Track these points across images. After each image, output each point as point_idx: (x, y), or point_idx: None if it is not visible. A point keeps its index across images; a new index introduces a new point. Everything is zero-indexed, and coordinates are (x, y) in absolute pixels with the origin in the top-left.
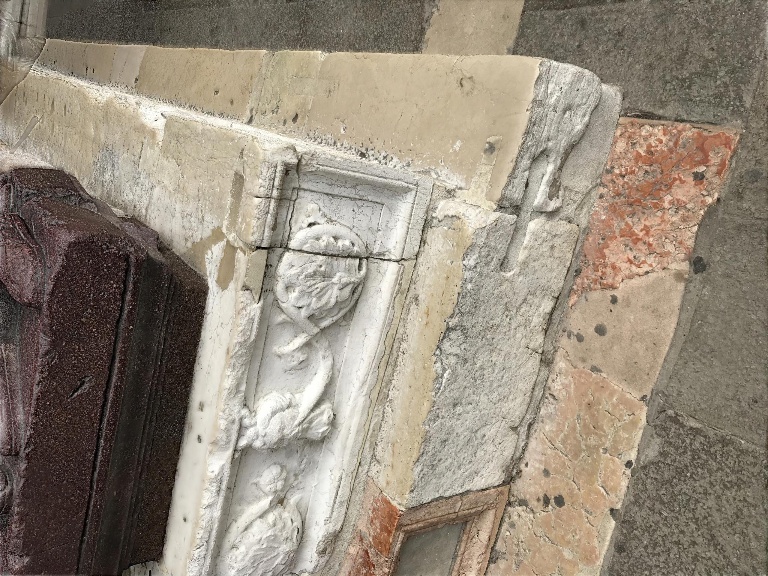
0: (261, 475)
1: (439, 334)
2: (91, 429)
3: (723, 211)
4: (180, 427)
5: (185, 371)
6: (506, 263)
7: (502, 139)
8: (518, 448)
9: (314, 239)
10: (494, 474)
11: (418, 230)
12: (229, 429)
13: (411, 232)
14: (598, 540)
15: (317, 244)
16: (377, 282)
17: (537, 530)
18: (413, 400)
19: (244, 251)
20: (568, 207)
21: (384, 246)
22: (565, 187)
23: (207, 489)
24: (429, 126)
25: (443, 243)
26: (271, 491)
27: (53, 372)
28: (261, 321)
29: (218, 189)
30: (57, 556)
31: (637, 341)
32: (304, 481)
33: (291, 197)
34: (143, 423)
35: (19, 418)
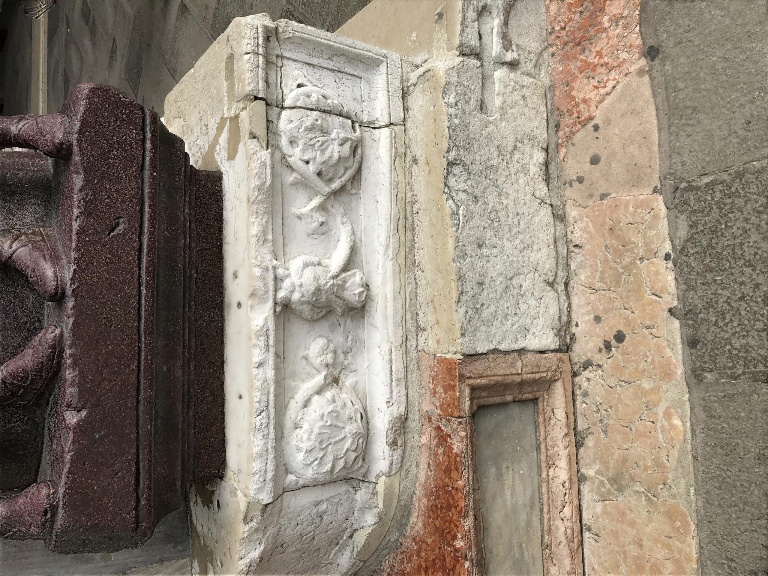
0: (309, 348)
1: (442, 171)
2: (131, 273)
3: (653, 1)
4: (220, 314)
5: (214, 255)
6: (485, 109)
7: (446, 3)
8: (563, 311)
9: (305, 96)
10: (546, 335)
11: (398, 98)
12: (265, 277)
13: (392, 99)
14: (670, 348)
15: (309, 100)
16: (374, 150)
17: (610, 381)
18: (438, 246)
19: (245, 107)
20: (526, 65)
21: (372, 116)
22: (517, 45)
23: (255, 345)
24: (387, 42)
25: (422, 98)
26: (322, 364)
27: (89, 208)
28: (274, 176)
29: (215, 91)
30: (115, 414)
31: (629, 146)
32: (355, 363)
33: (277, 64)
34: (182, 297)
35: (62, 262)
